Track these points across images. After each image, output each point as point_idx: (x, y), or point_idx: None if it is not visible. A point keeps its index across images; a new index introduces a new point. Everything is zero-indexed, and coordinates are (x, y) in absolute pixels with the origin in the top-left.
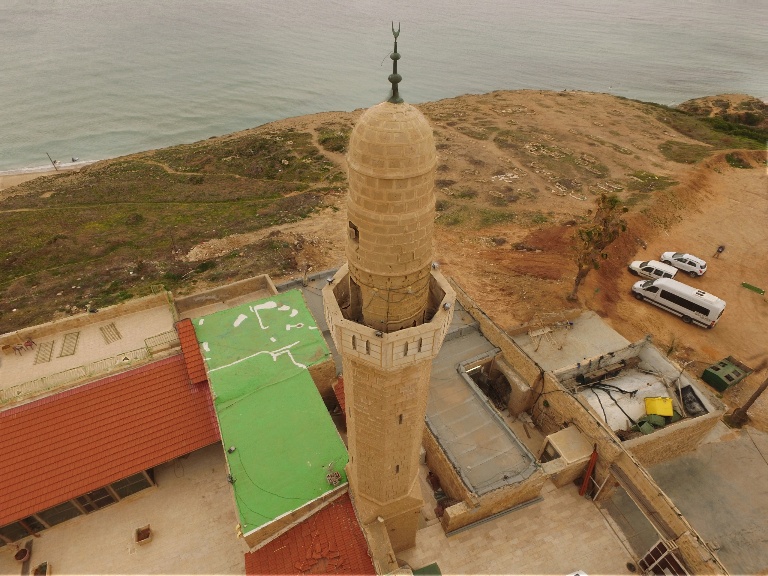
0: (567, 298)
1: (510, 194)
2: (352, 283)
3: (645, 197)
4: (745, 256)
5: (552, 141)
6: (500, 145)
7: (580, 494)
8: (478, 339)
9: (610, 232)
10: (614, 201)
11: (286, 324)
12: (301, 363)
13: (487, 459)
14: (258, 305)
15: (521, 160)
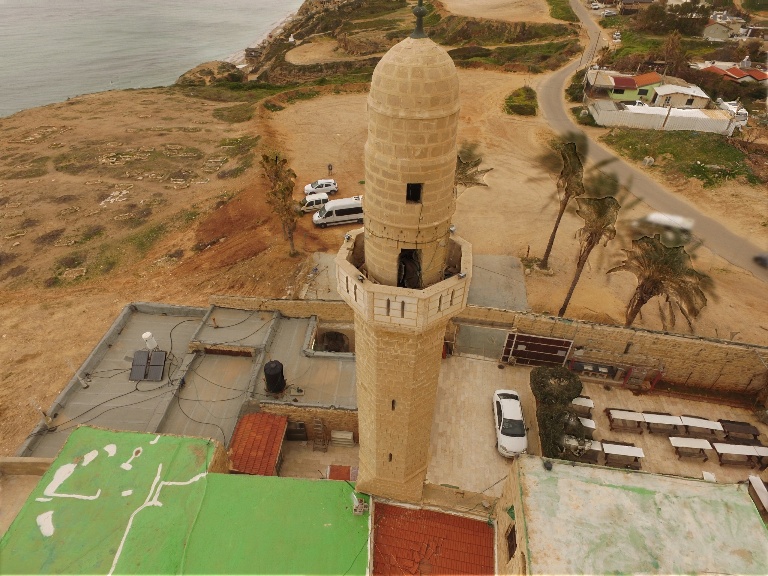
0: (290, 256)
1: (138, 210)
2: (403, 255)
3: (252, 156)
4: (342, 165)
5: (122, 146)
6: (71, 172)
7: (444, 358)
8: (290, 323)
9: (288, 183)
10: (233, 170)
11: (119, 466)
12: (193, 476)
13: None
14: (47, 487)
15: (112, 175)
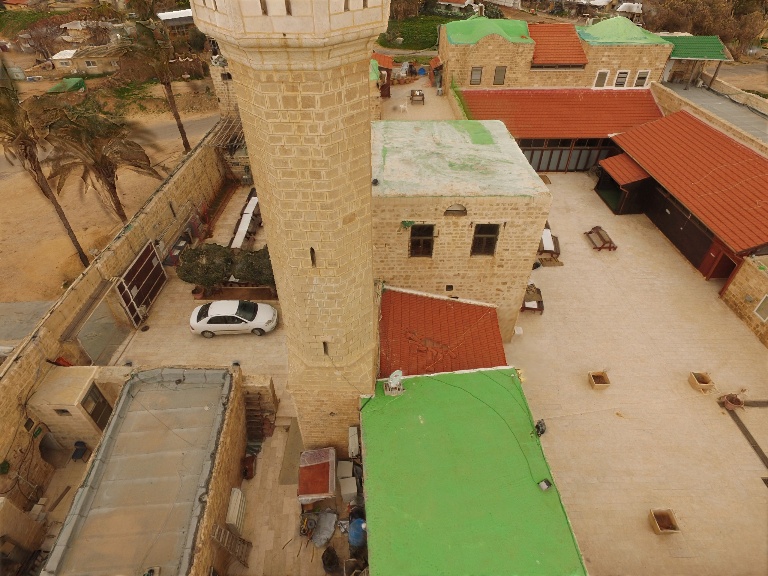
0: None
1: None
2: None
3: None
4: None
5: None
6: None
7: None
8: None
9: None
10: None
11: None
12: None
13: (176, 410)
14: None
15: None
